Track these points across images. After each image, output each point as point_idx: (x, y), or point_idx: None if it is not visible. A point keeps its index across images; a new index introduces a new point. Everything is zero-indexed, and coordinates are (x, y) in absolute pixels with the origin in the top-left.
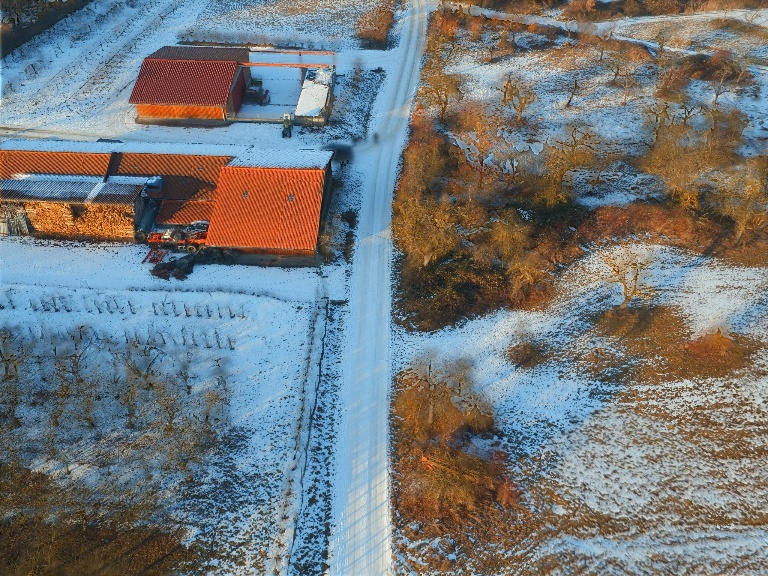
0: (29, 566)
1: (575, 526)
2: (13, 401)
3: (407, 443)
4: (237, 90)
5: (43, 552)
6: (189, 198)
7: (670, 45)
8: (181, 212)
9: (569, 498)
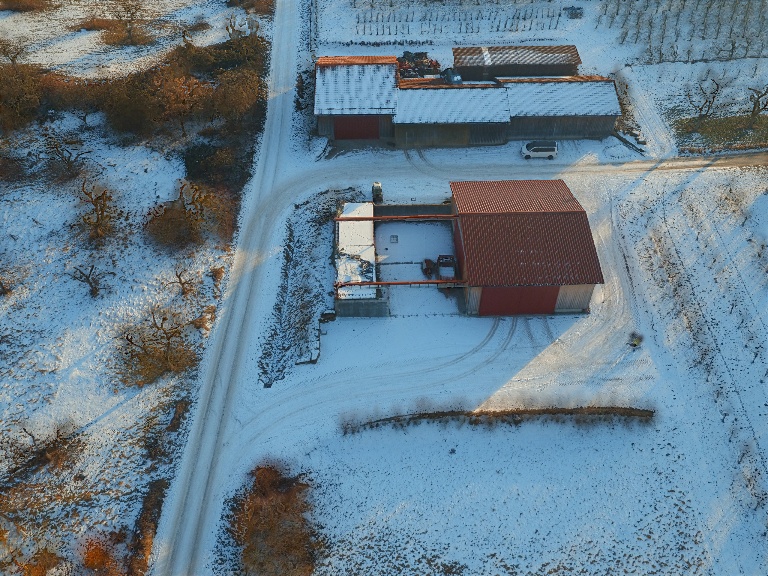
0: None
1: None
2: None
3: None
4: None
5: None
6: None
7: None
8: None
9: None
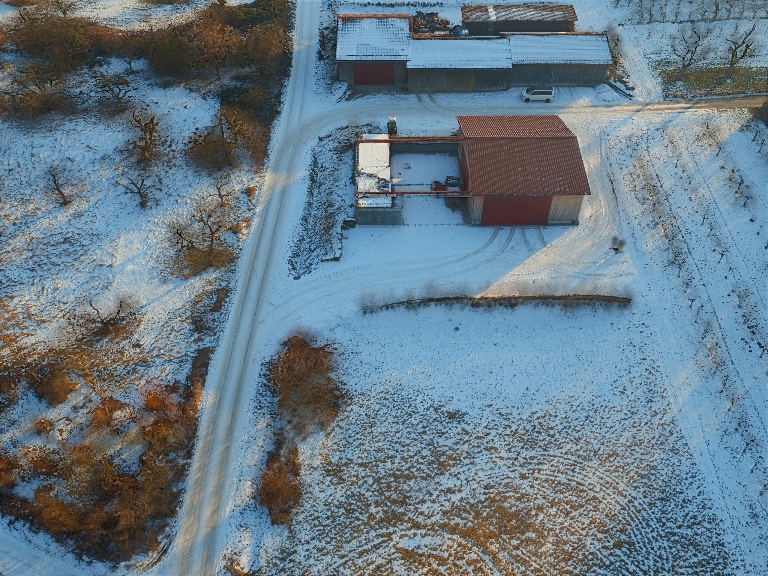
0: None
1: None
2: None
3: None
4: None
5: None
6: (436, 36)
7: None
8: (438, 35)
9: None
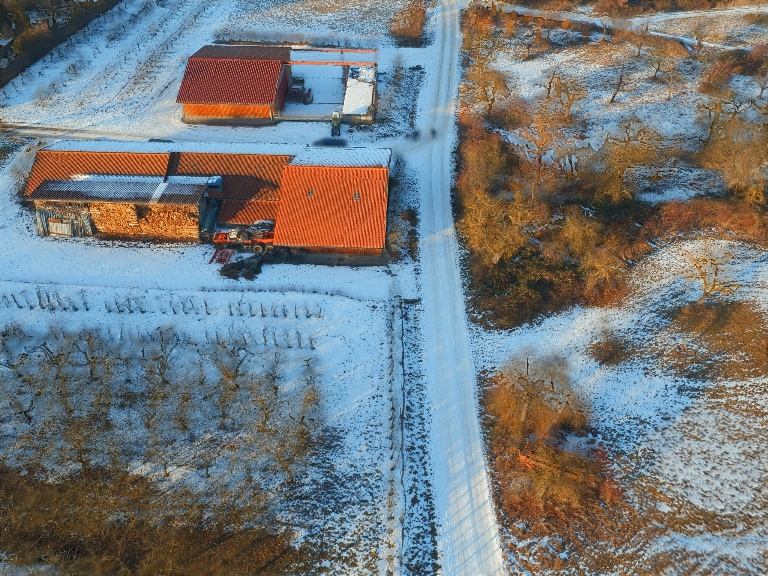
0: (140, 570)
1: (682, 523)
2: (101, 403)
3: (501, 442)
4: (281, 89)
5: (152, 555)
6: (250, 198)
7: (708, 40)
8: (243, 212)
9: (672, 495)
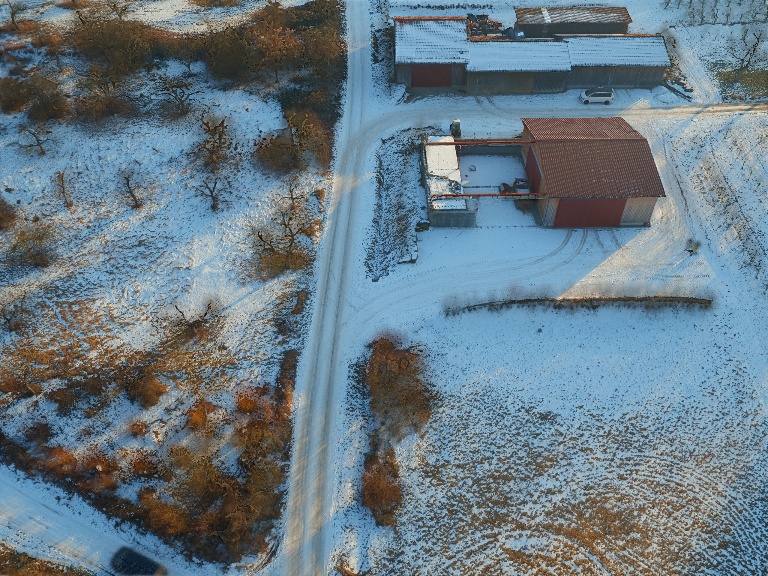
0: None
1: None
2: None
3: None
4: None
5: None
6: None
7: None
8: None
9: None
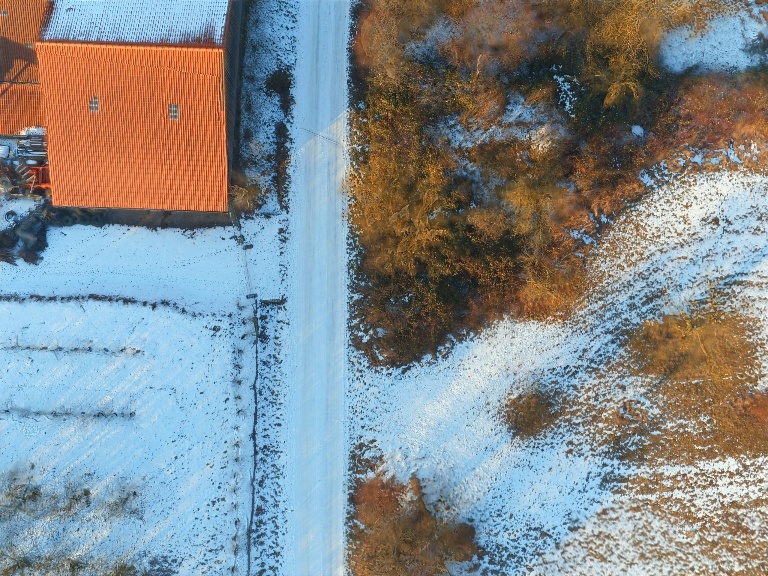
0: None
1: None
2: None
3: (368, 567)
4: None
5: None
6: (2, 79)
7: None
8: None
9: None
